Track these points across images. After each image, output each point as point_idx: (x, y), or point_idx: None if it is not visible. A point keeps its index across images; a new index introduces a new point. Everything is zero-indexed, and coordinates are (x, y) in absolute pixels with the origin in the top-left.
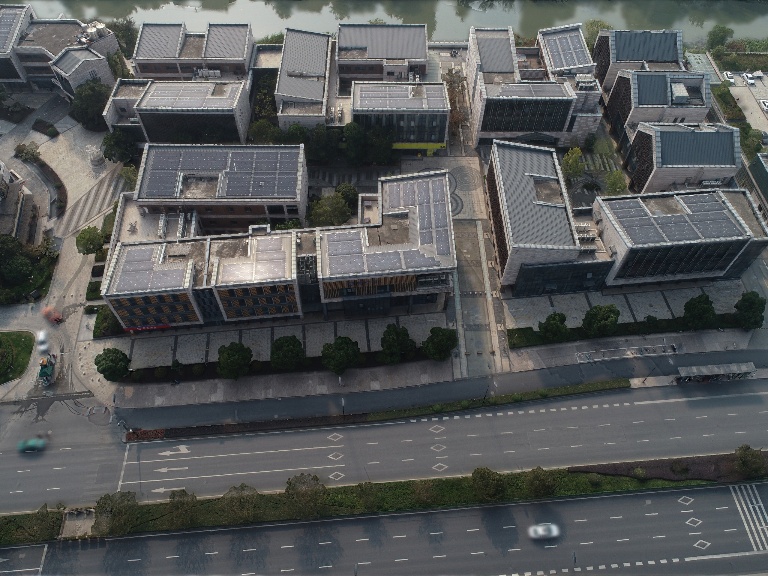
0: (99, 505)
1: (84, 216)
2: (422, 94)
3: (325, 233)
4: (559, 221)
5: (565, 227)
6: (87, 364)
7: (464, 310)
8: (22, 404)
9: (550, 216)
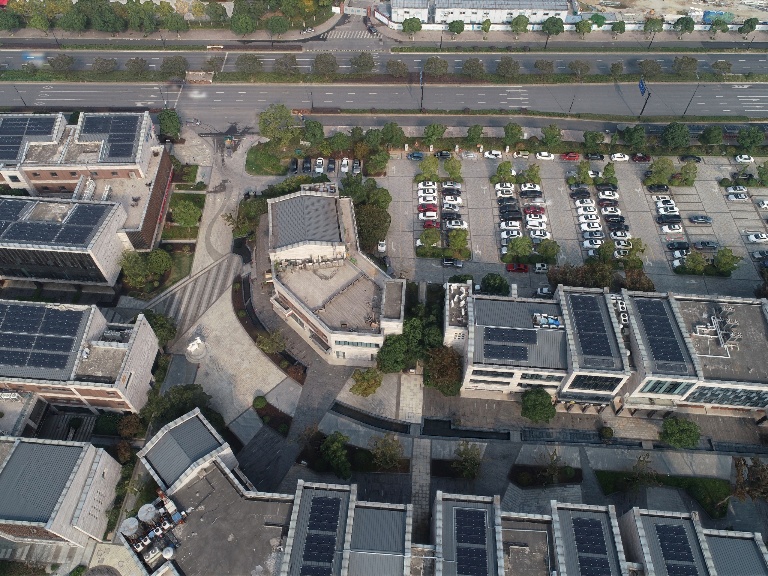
0: (178, 62)
1: (212, 276)
2: None
3: None
4: None
5: None
6: (203, 151)
7: None
8: (247, 132)
9: None
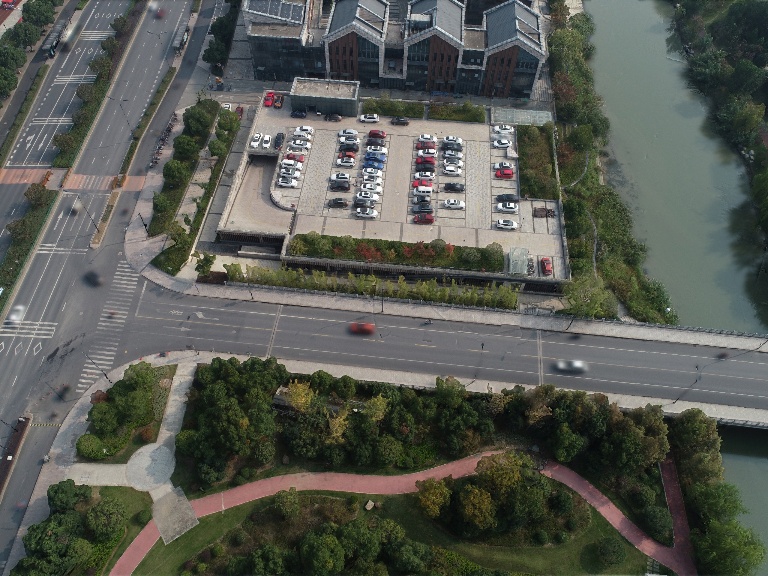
0: None
1: None
2: None
3: None
4: None
5: None
6: None
7: None
8: None
9: None
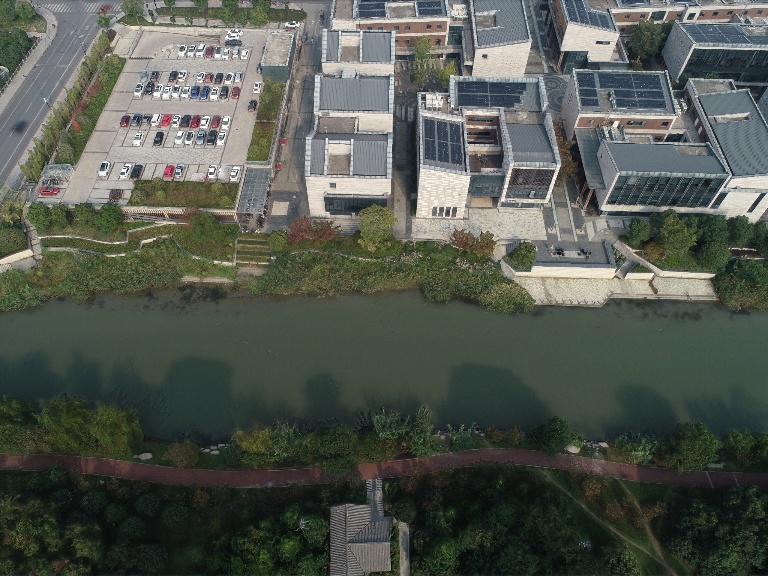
0: None
1: None
2: (601, 101)
3: (647, 3)
4: (481, 5)
5: (477, 2)
6: None
7: (532, 25)
8: None
9: (488, 6)
